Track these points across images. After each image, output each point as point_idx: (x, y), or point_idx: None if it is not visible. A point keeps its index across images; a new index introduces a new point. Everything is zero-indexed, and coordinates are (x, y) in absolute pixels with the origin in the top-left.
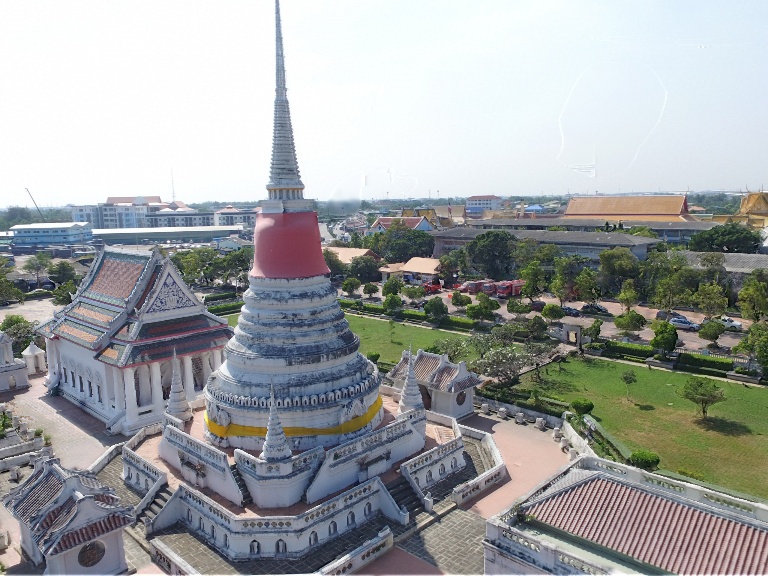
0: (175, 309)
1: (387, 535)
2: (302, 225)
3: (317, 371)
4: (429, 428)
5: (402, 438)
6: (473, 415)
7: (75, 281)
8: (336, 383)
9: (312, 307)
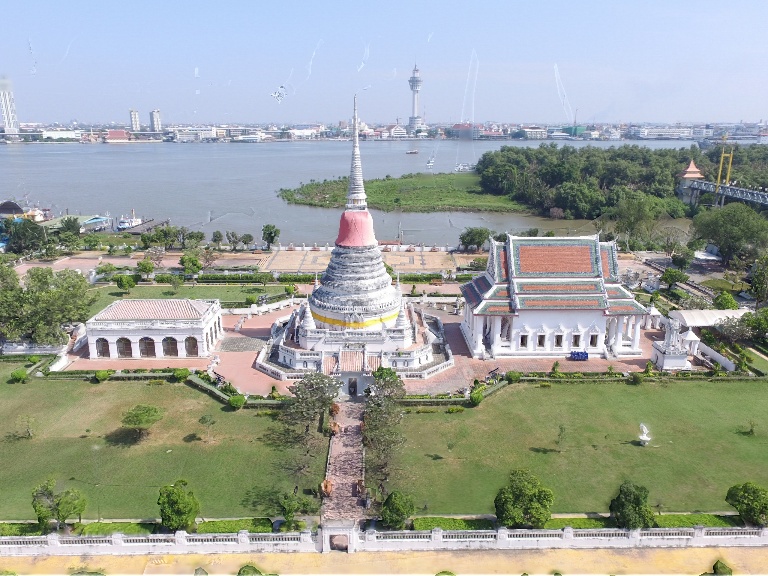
0: None
1: None
2: None
3: None
4: None
5: None
6: None
7: None
8: None
9: None
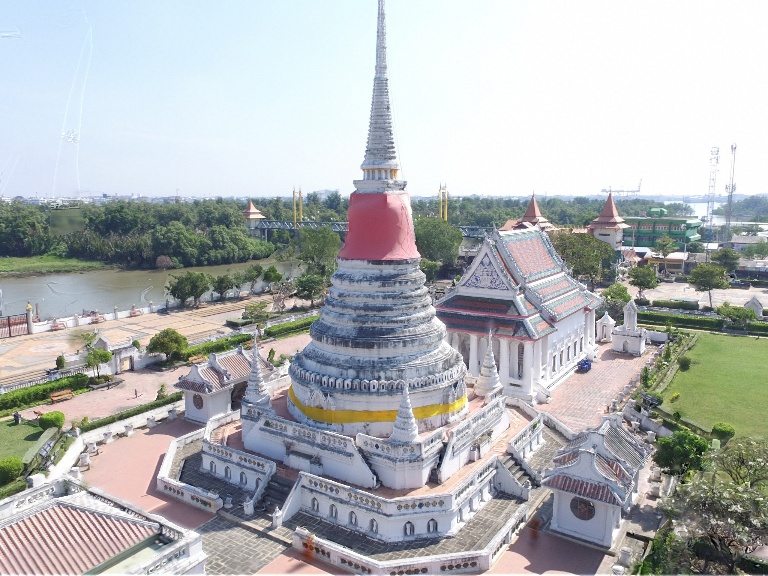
0: (488, 289)
1: (212, 499)
2: (361, 206)
3: (323, 350)
4: (441, 489)
5: (337, 454)
6: (598, 549)
7: (767, 274)
8: (324, 368)
9: (346, 289)
